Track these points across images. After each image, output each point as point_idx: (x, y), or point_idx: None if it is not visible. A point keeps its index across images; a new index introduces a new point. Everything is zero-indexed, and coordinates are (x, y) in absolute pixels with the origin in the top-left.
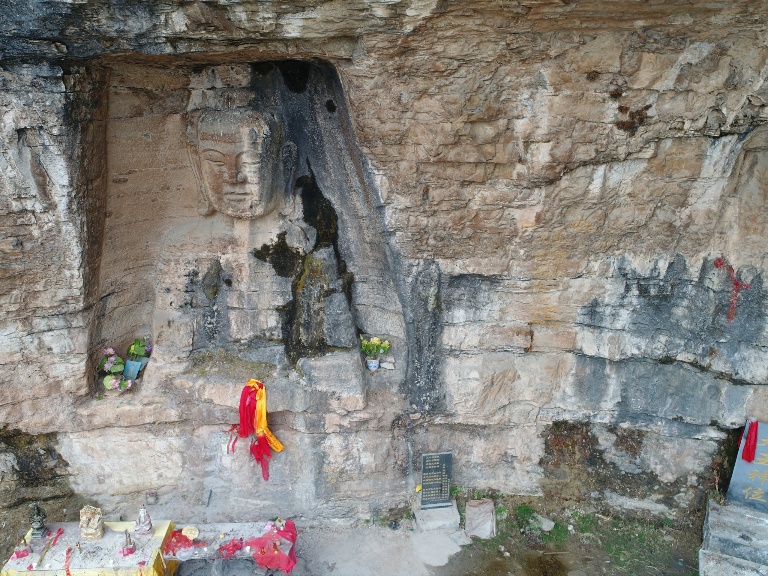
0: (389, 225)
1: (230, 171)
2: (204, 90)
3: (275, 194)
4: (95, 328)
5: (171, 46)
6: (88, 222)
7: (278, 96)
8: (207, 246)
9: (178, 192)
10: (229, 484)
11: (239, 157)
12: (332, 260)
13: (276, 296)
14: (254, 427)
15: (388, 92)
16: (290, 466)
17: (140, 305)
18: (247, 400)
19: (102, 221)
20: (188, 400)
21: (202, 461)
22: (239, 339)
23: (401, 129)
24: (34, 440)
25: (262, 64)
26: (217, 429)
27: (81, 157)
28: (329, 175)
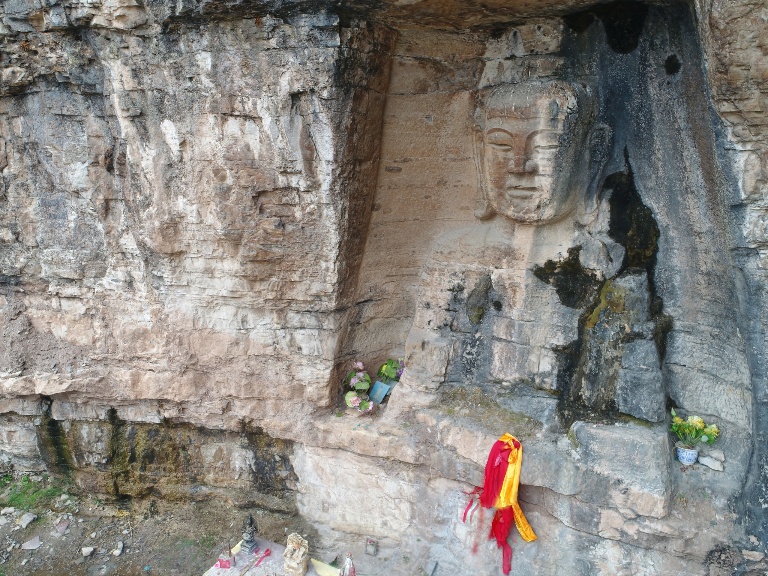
0: (749, 237)
1: (517, 157)
2: (501, 60)
3: (573, 193)
4: (347, 335)
5: None
6: (351, 209)
7: (596, 61)
8: (478, 256)
9: (455, 189)
10: (459, 562)
11: (531, 139)
12: (643, 292)
13: (556, 332)
14: (500, 498)
15: None
16: (541, 566)
17: (399, 320)
18: (497, 459)
19: (368, 213)
20: (429, 441)
21: (433, 521)
22: (501, 380)
23: None
24: (273, 443)
25: (579, 17)
26: (457, 487)
27: (350, 129)
28: (655, 171)
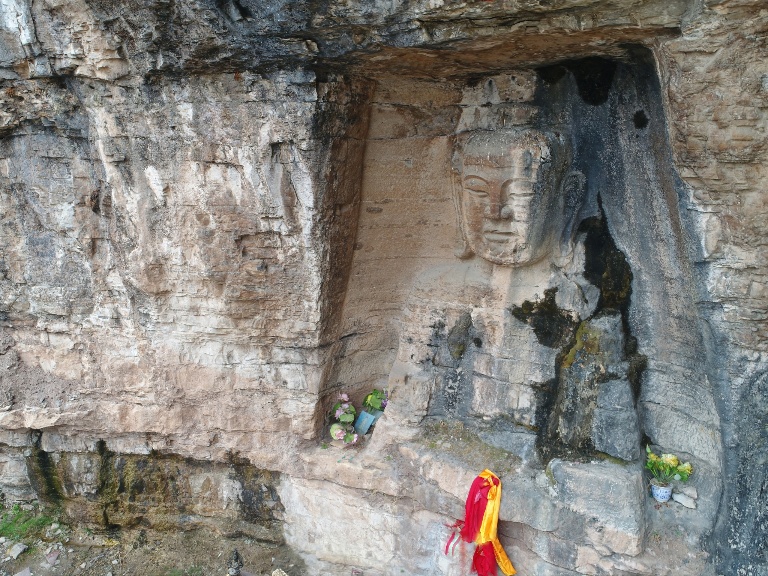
0: (713, 292)
1: (493, 203)
2: (478, 107)
3: (548, 237)
4: (331, 369)
5: (427, 33)
6: (332, 251)
7: (568, 111)
8: (458, 295)
9: (436, 228)
10: None
11: (506, 186)
12: (617, 334)
13: (534, 369)
14: (481, 533)
15: (739, 74)
16: None
17: (383, 352)
18: (476, 495)
19: (349, 253)
20: (411, 474)
21: (416, 553)
22: (481, 414)
23: (755, 137)
24: (260, 474)
25: (551, 69)
26: (439, 519)
27: (330, 177)
28: (627, 217)
